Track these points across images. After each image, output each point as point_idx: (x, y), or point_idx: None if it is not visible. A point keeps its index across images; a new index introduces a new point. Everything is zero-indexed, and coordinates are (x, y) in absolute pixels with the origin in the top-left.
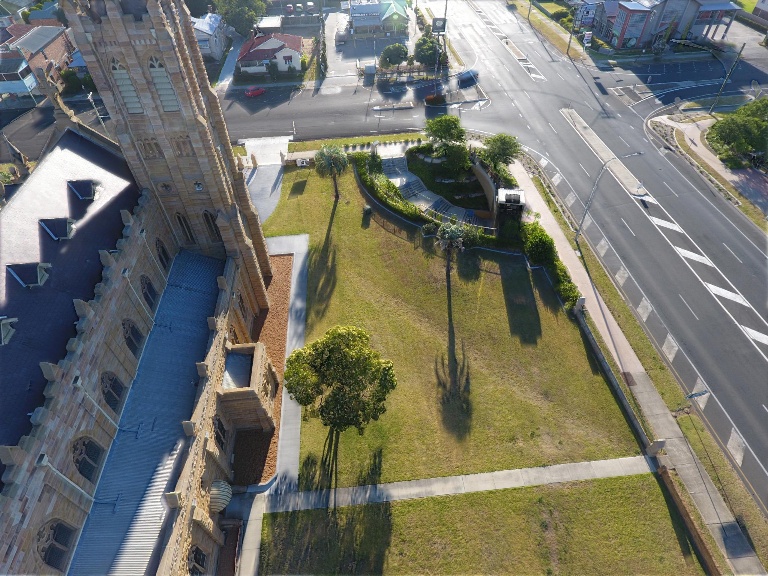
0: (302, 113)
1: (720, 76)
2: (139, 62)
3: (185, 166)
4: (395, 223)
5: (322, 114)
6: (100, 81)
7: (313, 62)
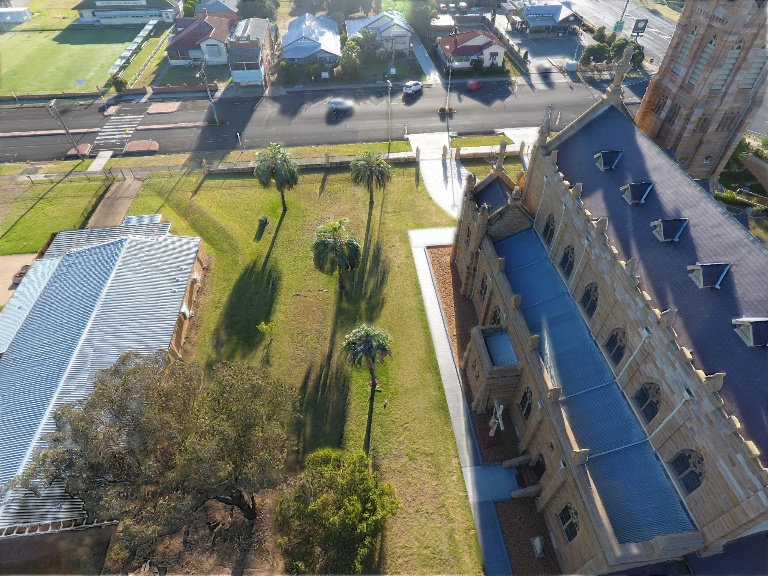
0: (538, 106)
1: None
2: (761, 43)
3: (713, 140)
4: None
5: (558, 107)
6: (723, 59)
7: (505, 59)
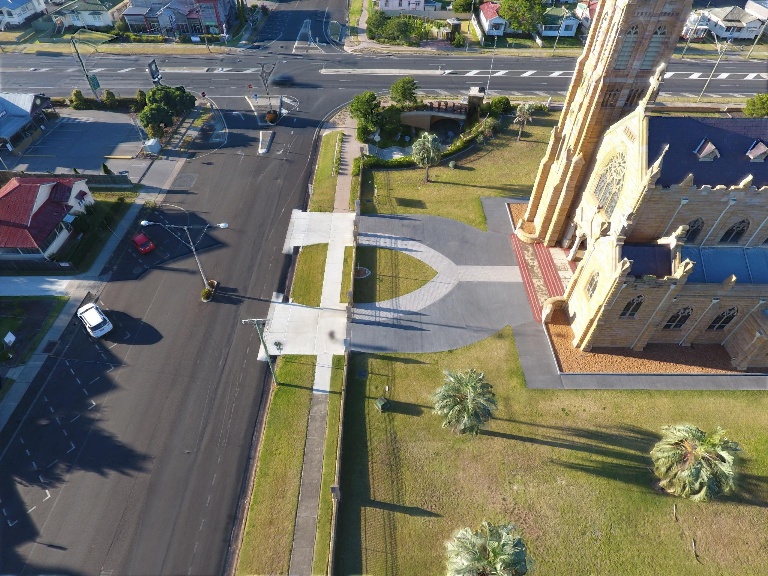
0: (242, 200)
1: (299, 20)
2: None
3: None
4: (468, 155)
5: (254, 186)
6: None
7: None
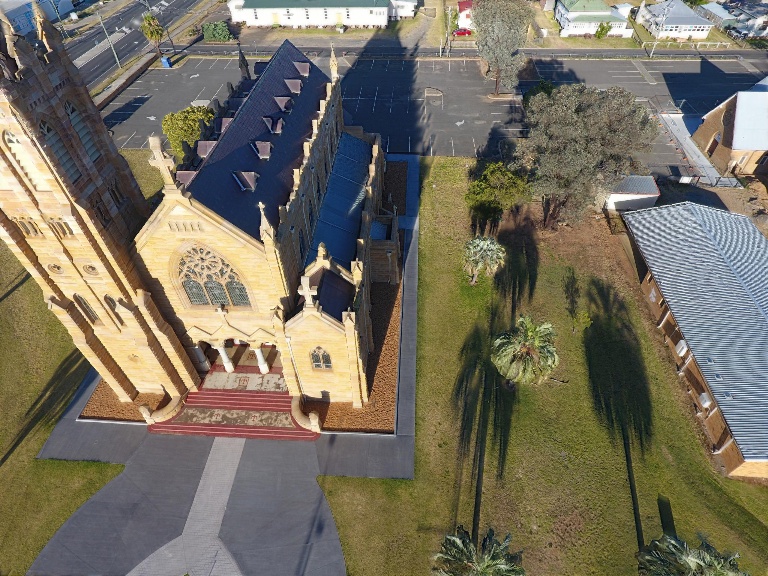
0: None
1: None
2: None
3: None
4: None
5: None
6: None
7: None
